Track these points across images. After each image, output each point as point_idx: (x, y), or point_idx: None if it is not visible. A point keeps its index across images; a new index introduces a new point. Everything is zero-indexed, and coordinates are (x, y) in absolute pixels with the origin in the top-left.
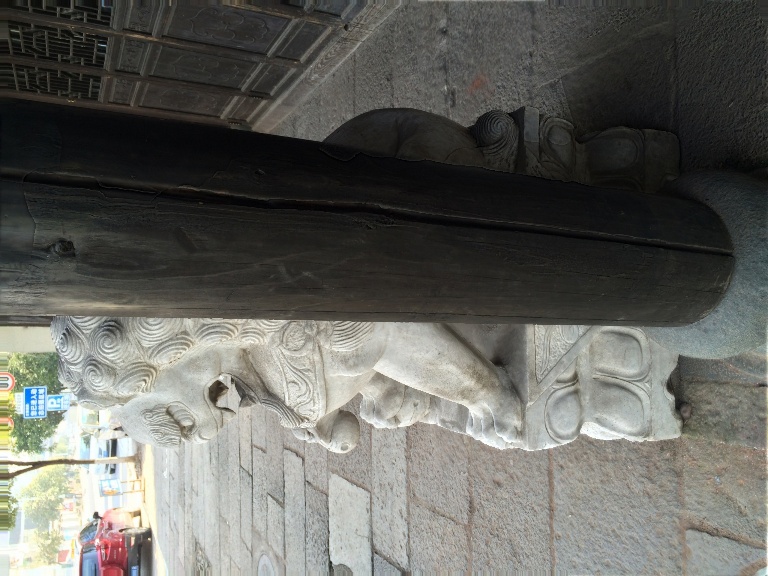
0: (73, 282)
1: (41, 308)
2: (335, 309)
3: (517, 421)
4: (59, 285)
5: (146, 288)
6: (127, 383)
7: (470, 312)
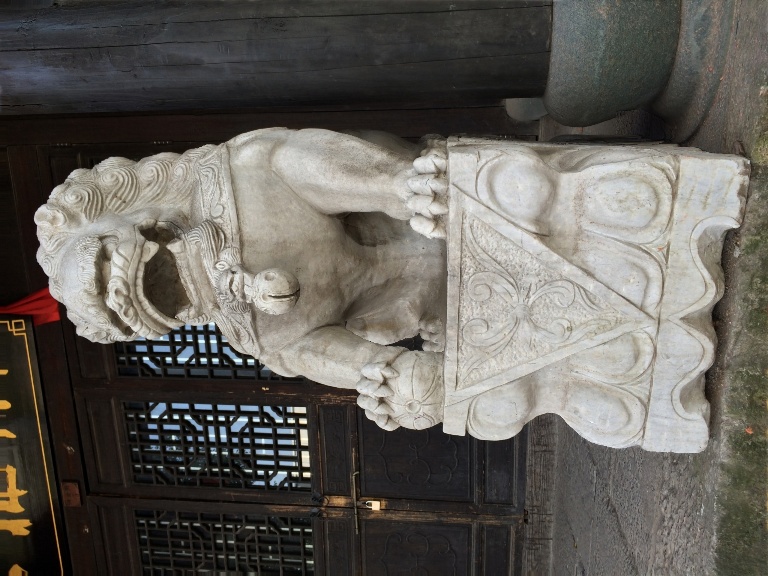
0: (51, 13)
1: (31, 33)
2: (195, 18)
3: (437, 153)
4: (44, 15)
5: (85, 13)
6: (74, 188)
7: (298, 13)
